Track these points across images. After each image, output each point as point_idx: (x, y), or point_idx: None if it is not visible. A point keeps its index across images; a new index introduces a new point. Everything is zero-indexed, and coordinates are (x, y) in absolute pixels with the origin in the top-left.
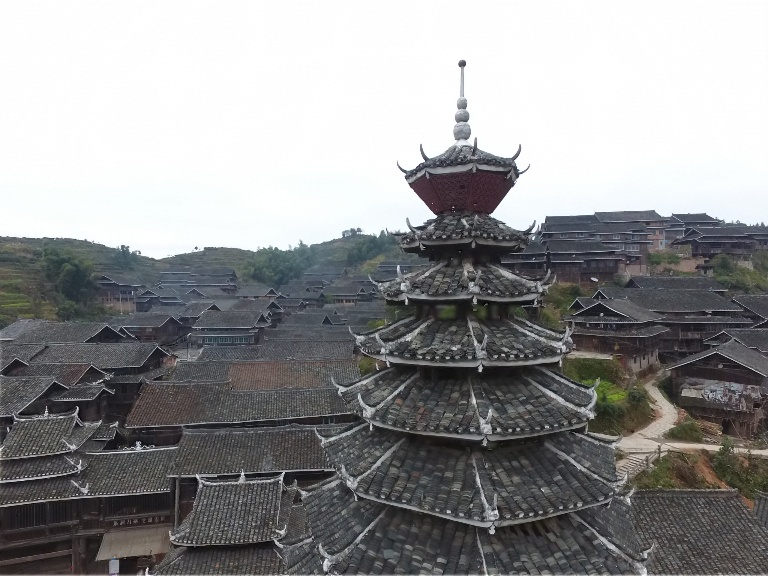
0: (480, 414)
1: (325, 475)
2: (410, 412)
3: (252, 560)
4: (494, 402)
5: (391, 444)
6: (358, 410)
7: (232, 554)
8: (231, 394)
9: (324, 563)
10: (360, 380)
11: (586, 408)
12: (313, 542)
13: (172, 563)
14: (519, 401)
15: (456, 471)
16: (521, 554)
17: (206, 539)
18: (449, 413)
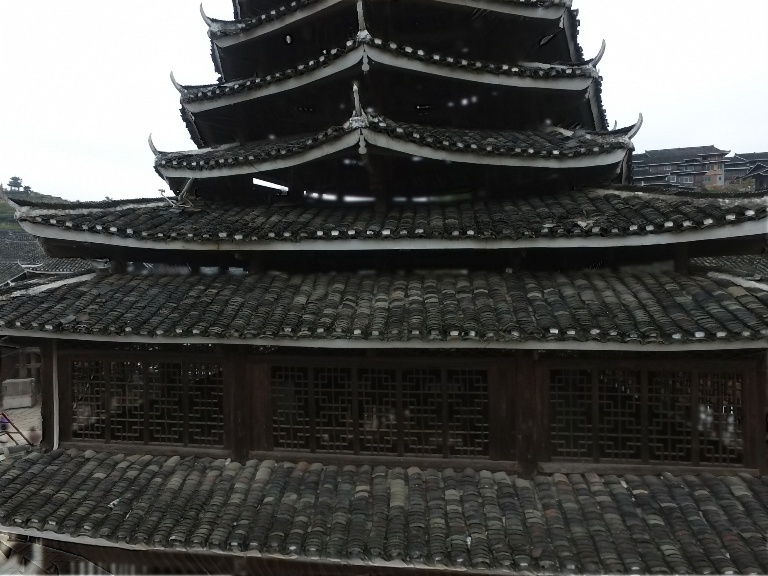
0: None
1: None
2: None
3: None
4: None
5: None
6: None
7: None
8: None
9: None
10: None
11: None
12: None
13: None
14: None
15: None
16: None
17: None
18: None
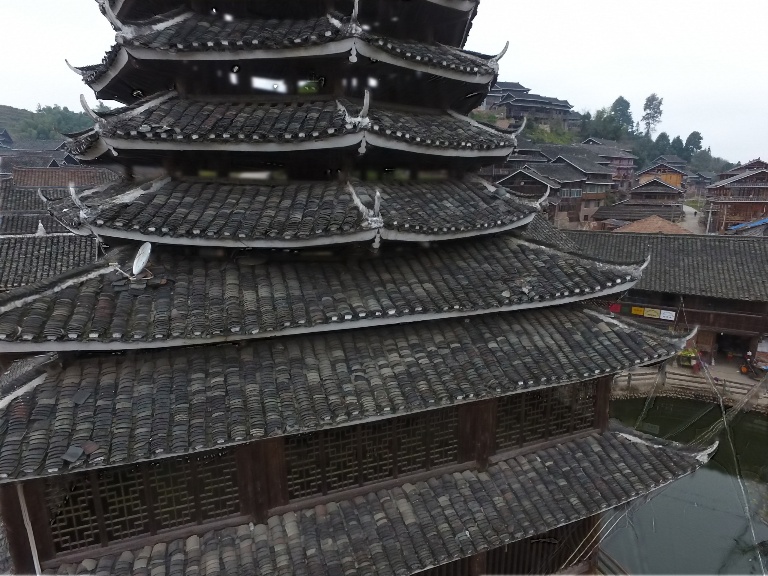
0: None
1: None
2: None
3: None
4: None
5: None
6: None
7: None
8: (15, 190)
9: None
10: None
11: None
12: None
13: None
14: None
15: None
16: None
17: None
18: None
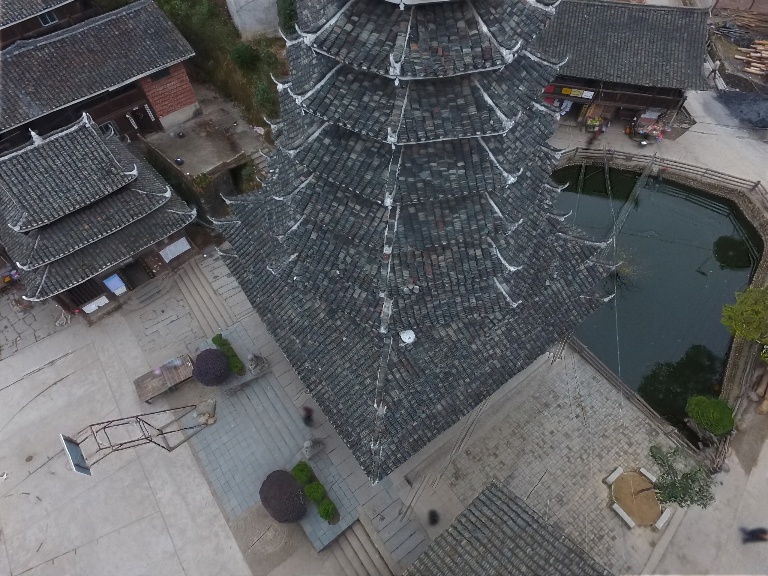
0: (502, 45)
1: (110, 94)
2: (430, 56)
3: (117, 207)
4: (495, 23)
5: (406, 90)
6: (373, 67)
7: (92, 211)
8: None
9: (387, 202)
10: (328, 20)
11: (553, 6)
12: (311, 185)
13: (35, 247)
14: (507, 14)
15: (466, 96)
16: (504, 138)
17: (56, 212)
18: (467, 48)
